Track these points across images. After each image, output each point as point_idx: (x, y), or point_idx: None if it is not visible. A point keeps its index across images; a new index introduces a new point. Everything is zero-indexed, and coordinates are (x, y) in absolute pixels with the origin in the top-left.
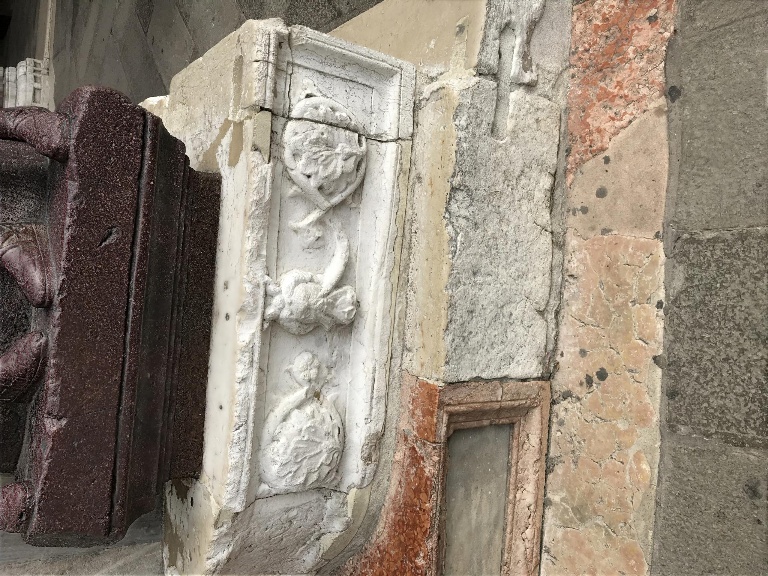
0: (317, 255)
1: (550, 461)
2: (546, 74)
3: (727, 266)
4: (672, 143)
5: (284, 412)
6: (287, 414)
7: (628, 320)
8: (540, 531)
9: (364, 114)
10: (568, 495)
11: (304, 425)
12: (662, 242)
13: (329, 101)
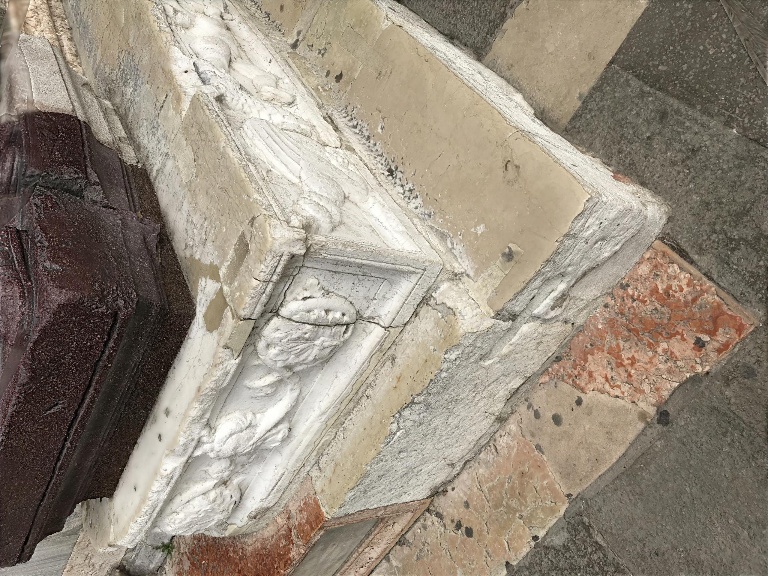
0: (264, 400)
1: (403, 539)
2: (578, 302)
3: (594, 572)
4: (631, 450)
5: (189, 498)
6: (192, 498)
7: (509, 523)
8: (372, 570)
9: (364, 301)
10: (402, 569)
11: (203, 508)
12: (569, 504)
13: (327, 303)
